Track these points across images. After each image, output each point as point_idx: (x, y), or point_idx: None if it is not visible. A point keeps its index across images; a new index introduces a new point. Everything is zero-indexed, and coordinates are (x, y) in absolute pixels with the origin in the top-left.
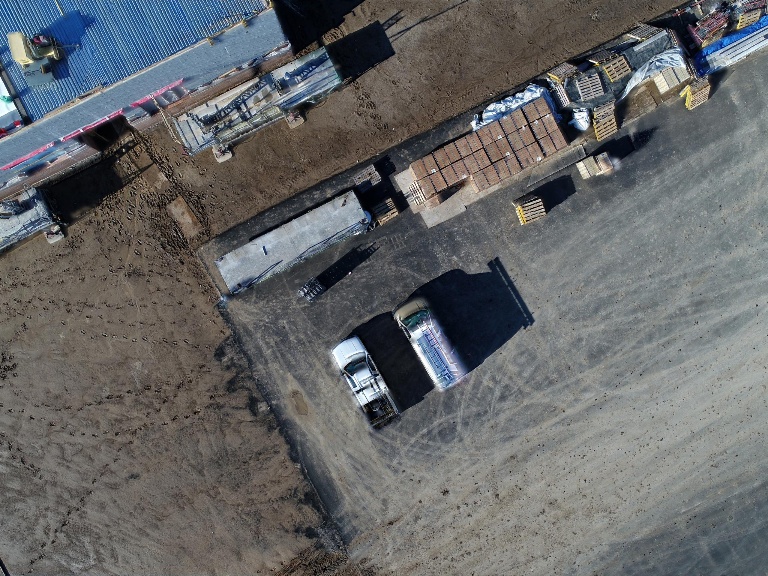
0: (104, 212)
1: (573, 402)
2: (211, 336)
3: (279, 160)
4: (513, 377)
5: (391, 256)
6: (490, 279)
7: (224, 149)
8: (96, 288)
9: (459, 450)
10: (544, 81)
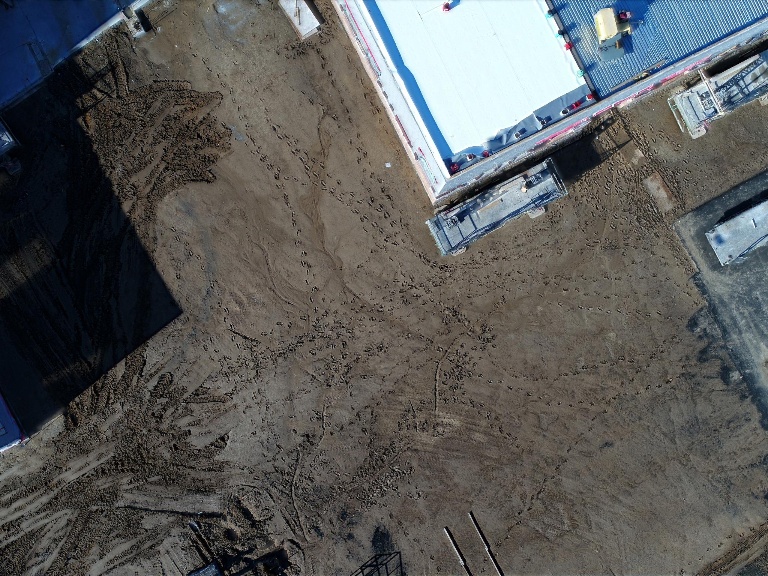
0: (582, 187)
1: None
2: (684, 307)
3: (750, 136)
4: None
5: None
6: None
7: None
8: (573, 261)
9: None
10: None
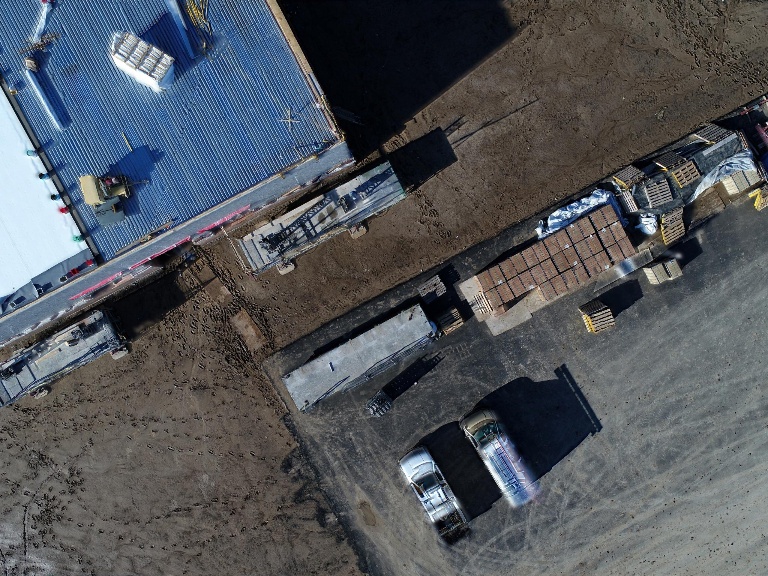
0: (168, 327)
1: (642, 508)
2: (277, 448)
3: (342, 271)
4: (581, 484)
5: (457, 365)
6: (557, 386)
7: (287, 261)
8: (161, 402)
9: (528, 558)
10: (609, 184)
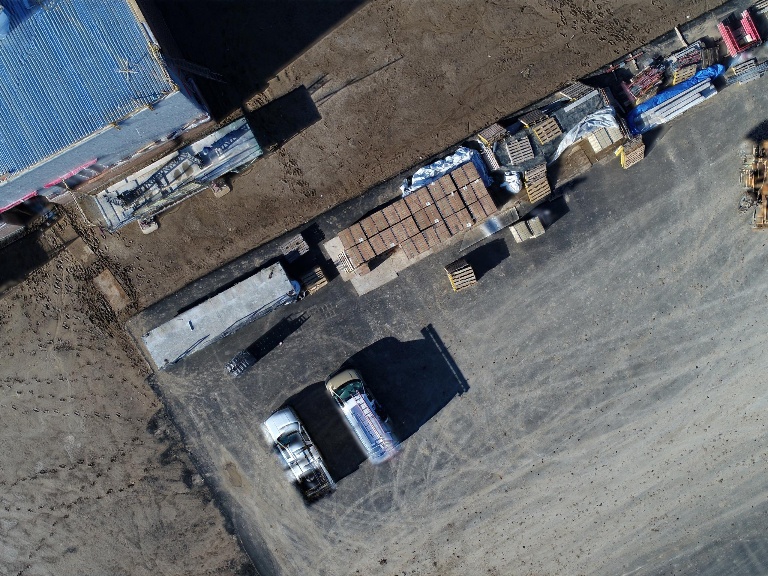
0: (31, 287)
1: (510, 468)
2: (143, 409)
3: (206, 230)
4: (449, 444)
5: (322, 325)
6: (423, 346)
7: (150, 221)
8: (26, 363)
9: (395, 519)
10: (475, 143)
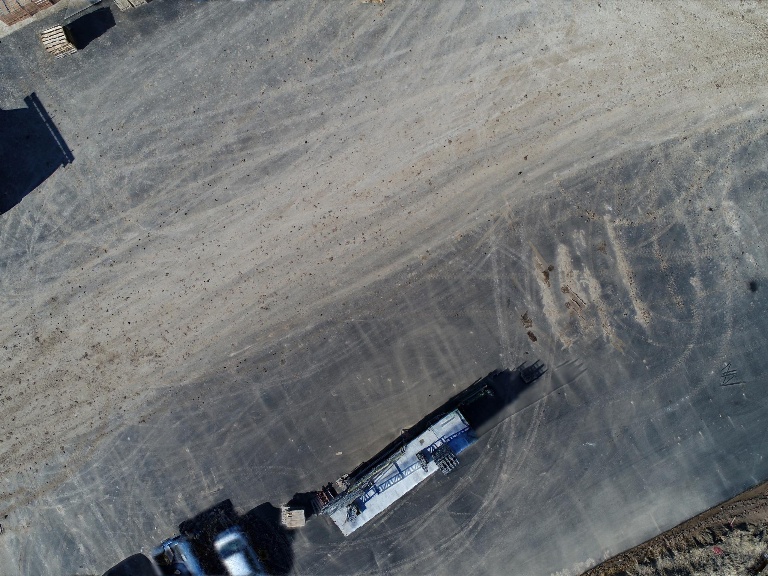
0: None
1: (115, 242)
2: None
3: None
4: (52, 216)
5: None
6: (27, 115)
7: None
8: None
9: None
10: None
